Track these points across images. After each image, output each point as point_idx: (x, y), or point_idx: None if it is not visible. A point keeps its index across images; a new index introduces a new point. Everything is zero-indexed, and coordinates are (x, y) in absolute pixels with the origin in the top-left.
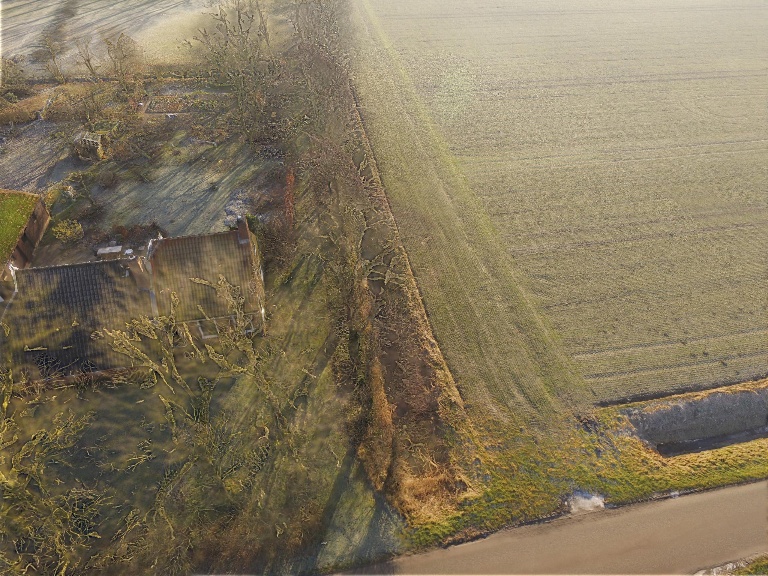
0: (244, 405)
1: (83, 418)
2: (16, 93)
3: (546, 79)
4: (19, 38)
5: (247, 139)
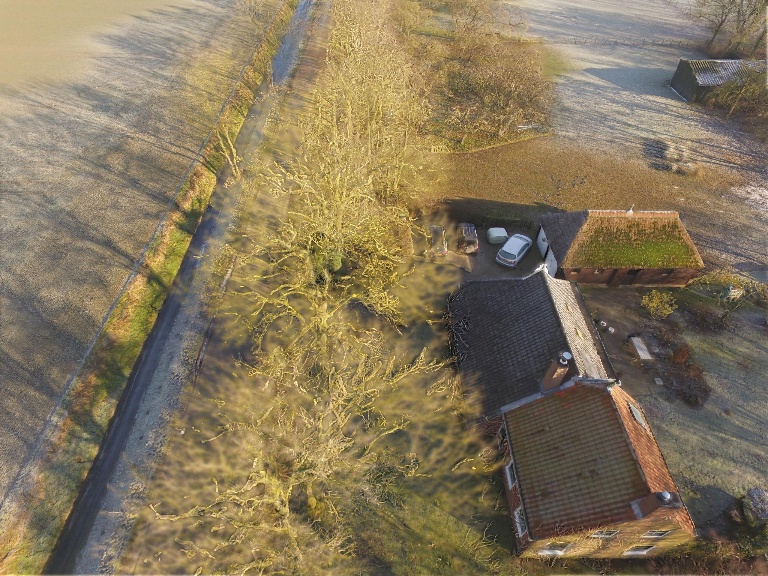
0: (411, 524)
1: (361, 356)
2: None
3: None
4: None
5: None
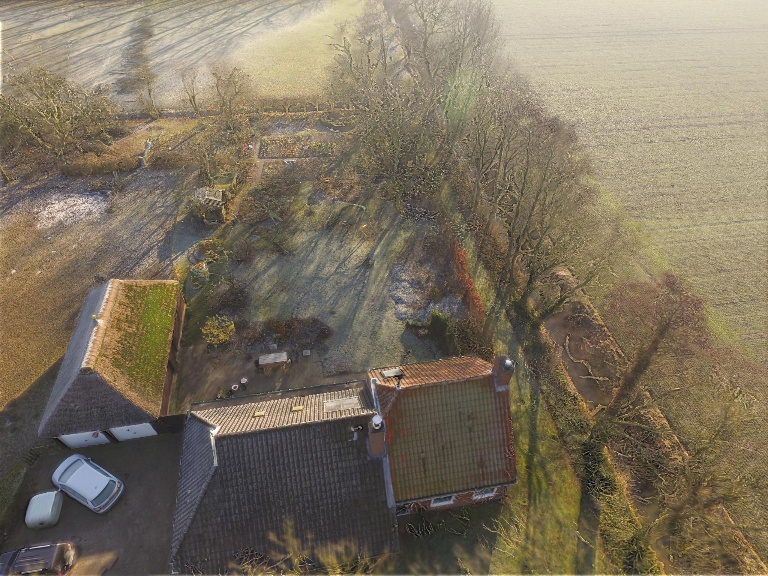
0: None
1: None
2: (110, 132)
3: (696, 115)
4: (99, 63)
5: (384, 194)
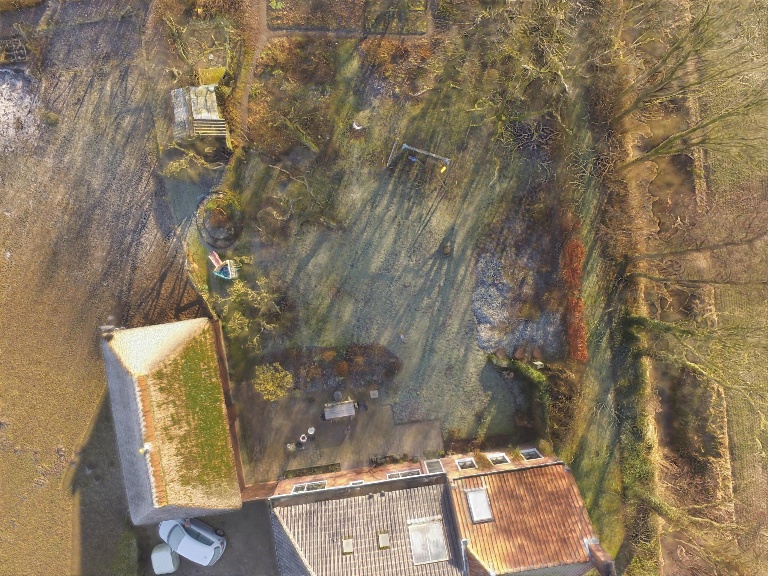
0: None
1: None
2: None
3: None
4: None
5: (476, 81)
